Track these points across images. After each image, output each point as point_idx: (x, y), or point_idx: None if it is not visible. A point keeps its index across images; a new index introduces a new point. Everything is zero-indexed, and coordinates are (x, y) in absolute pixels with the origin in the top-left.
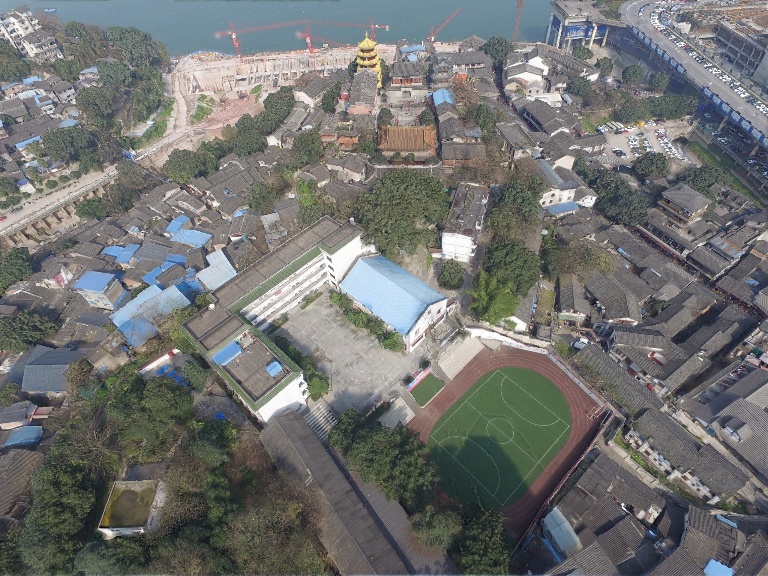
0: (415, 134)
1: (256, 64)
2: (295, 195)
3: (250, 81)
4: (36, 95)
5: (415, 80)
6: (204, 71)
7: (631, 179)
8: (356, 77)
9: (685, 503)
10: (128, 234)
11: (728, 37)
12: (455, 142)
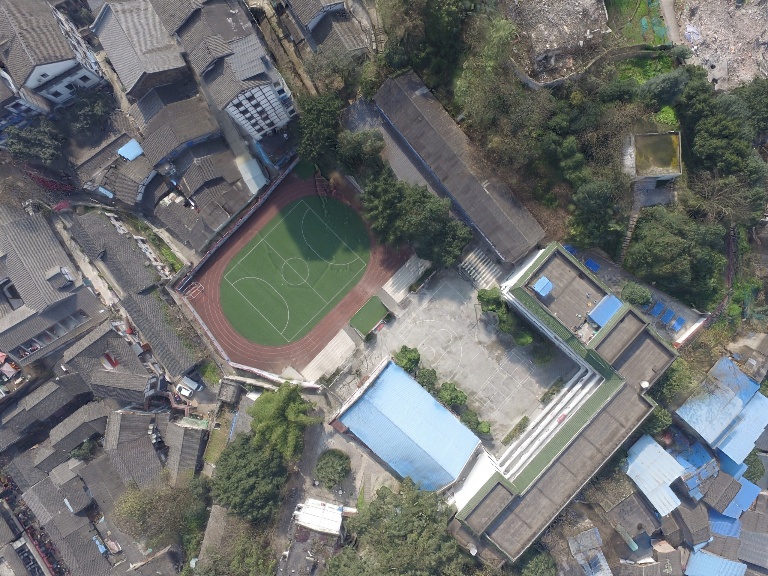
0: None
1: None
2: None
3: None
4: None
5: None
6: None
7: None
8: None
9: (137, 214)
10: None
11: None
12: None
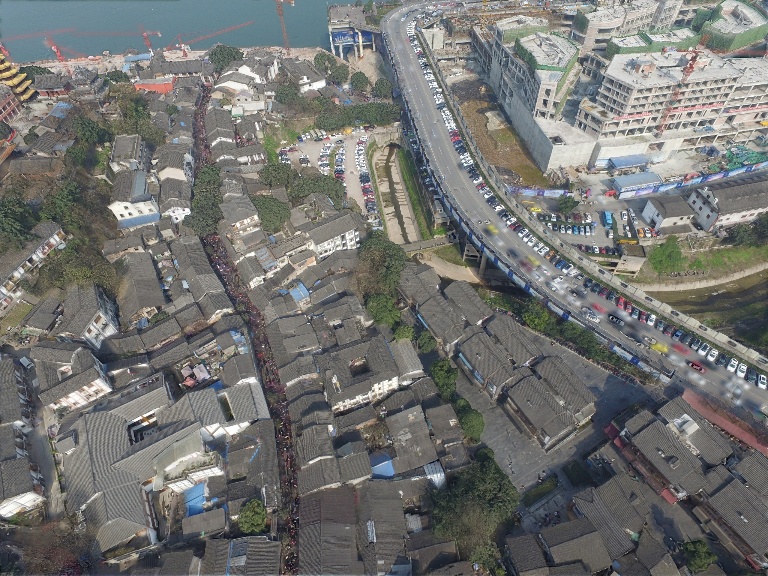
0: None
1: None
2: None
3: None
4: None
5: (61, 92)
6: None
7: (237, 189)
8: None
9: None
10: None
11: (477, 42)
12: (38, 156)
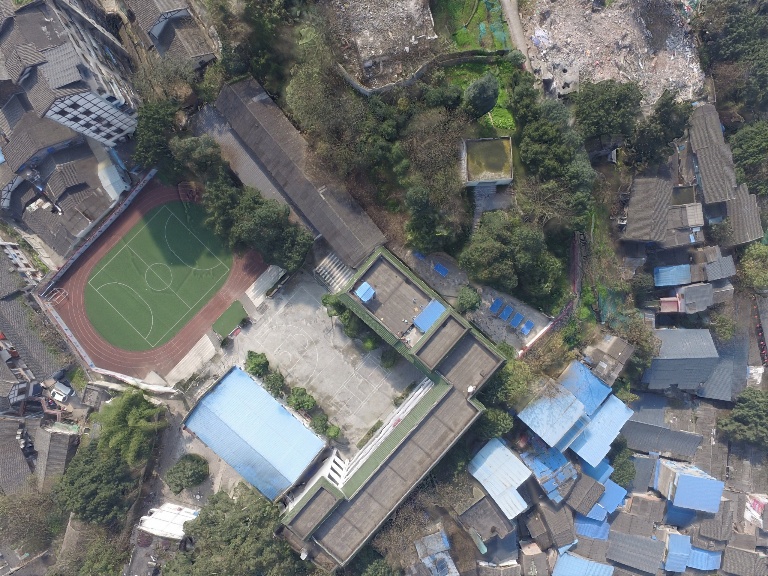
0: None
1: None
2: None
3: None
4: None
5: None
6: None
7: None
8: None
9: (7, 220)
10: None
11: None
12: None
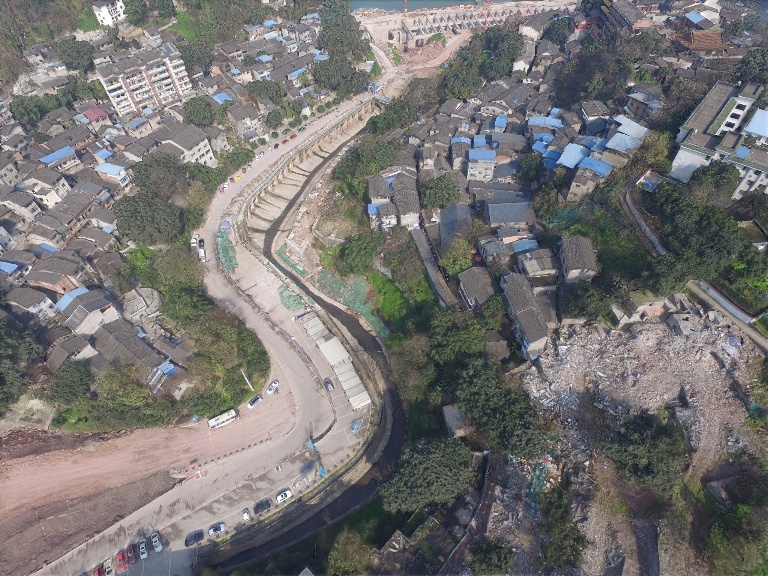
0: (714, 37)
1: (420, 18)
2: (634, 84)
3: (419, 32)
4: (277, 36)
5: (654, 8)
6: (375, 24)
7: None
8: (617, 3)
9: None
10: (458, 131)
11: None
12: None
